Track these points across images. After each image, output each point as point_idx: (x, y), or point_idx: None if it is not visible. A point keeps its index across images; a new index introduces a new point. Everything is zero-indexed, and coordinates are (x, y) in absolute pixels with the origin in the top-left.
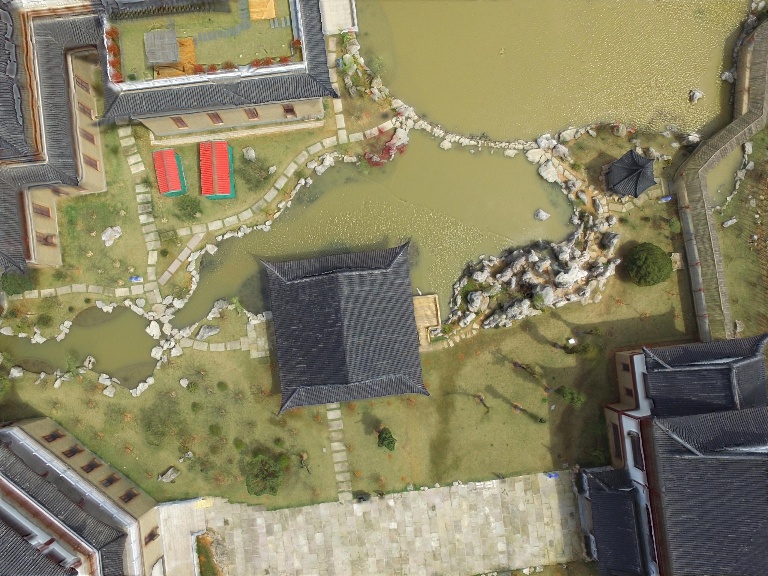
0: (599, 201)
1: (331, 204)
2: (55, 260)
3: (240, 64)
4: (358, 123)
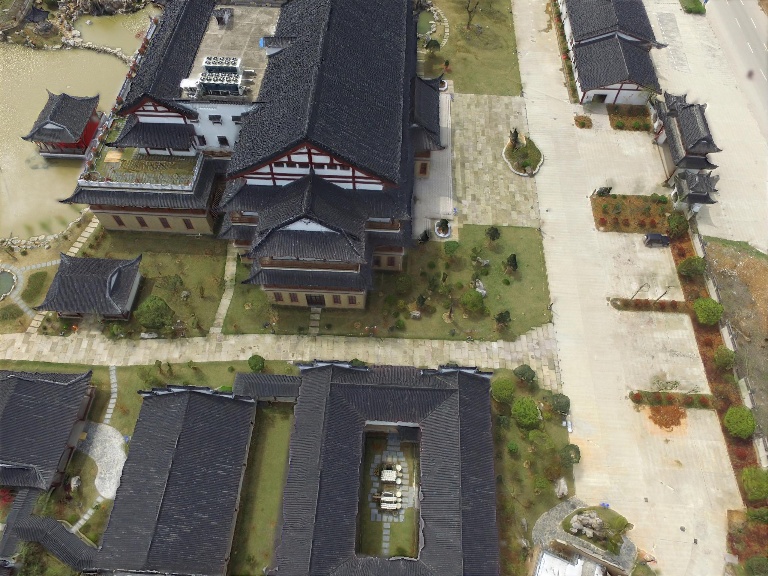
0: (59, 23)
1: None
2: None
3: None
4: None
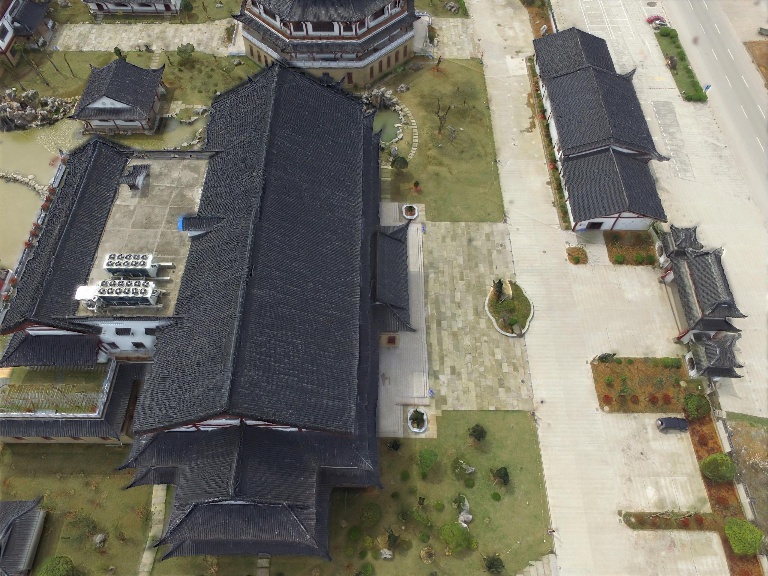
0: None
1: None
2: None
3: None
4: None
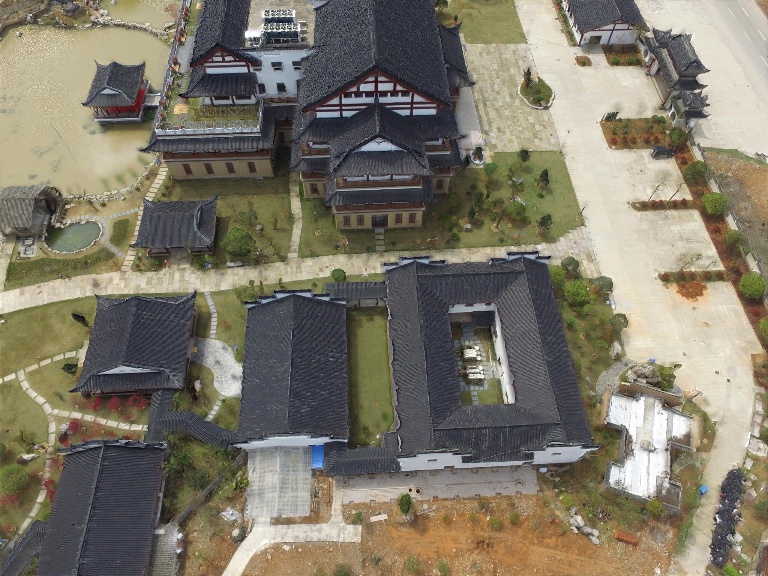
0: None
1: None
2: None
3: None
4: None
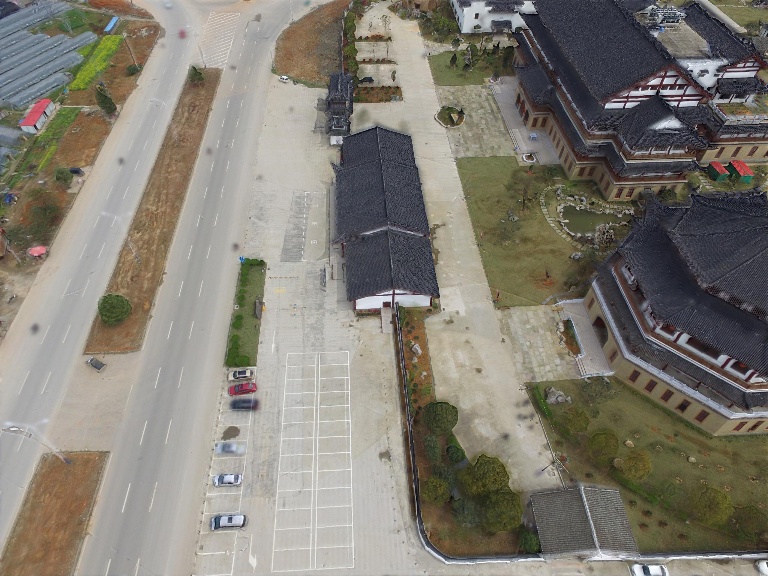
0: None
1: None
2: None
3: None
4: None
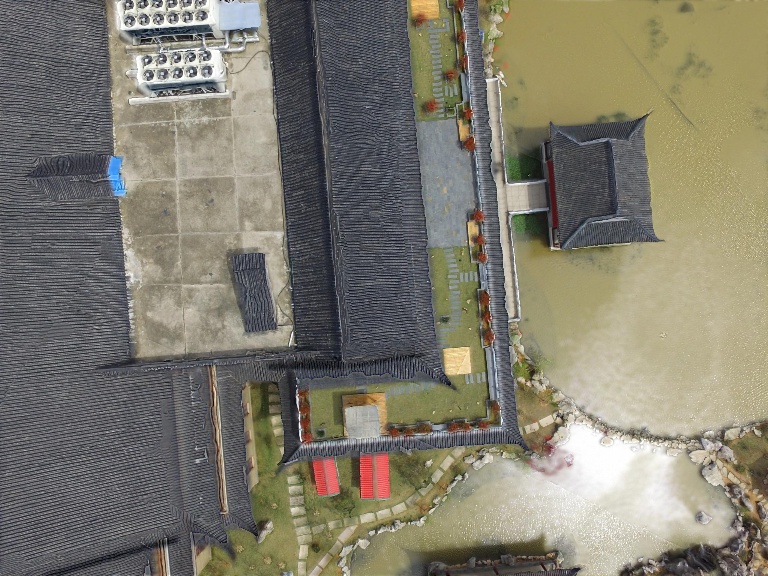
0: (763, 505)
1: (486, 497)
2: (208, 561)
3: (433, 422)
4: (518, 417)
